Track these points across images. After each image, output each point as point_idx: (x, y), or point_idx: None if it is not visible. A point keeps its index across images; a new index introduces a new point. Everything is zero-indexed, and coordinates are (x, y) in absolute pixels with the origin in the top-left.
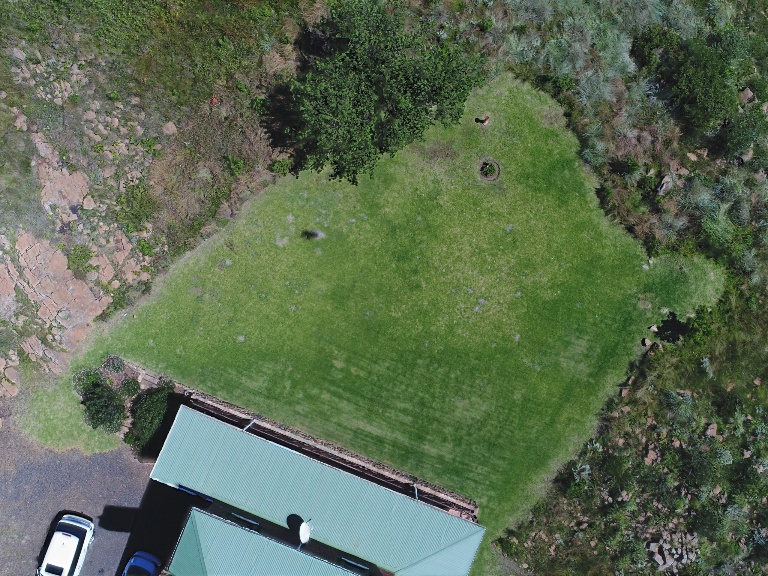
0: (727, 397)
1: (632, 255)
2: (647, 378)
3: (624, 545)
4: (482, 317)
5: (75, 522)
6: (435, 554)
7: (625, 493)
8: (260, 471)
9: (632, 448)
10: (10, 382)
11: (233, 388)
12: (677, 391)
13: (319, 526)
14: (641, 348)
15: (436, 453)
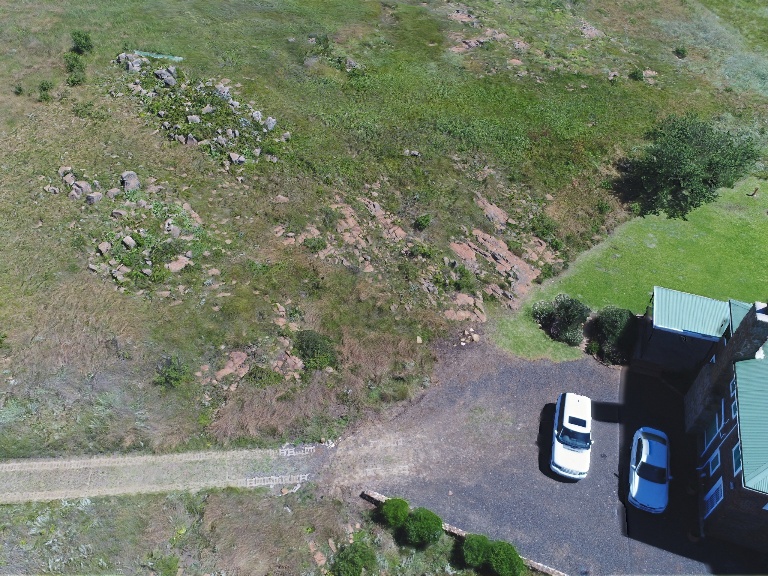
0: None
1: None
2: None
3: None
4: None
5: None
6: None
7: None
8: None
9: None
10: (481, 311)
11: None
12: None
13: None
14: None
15: None
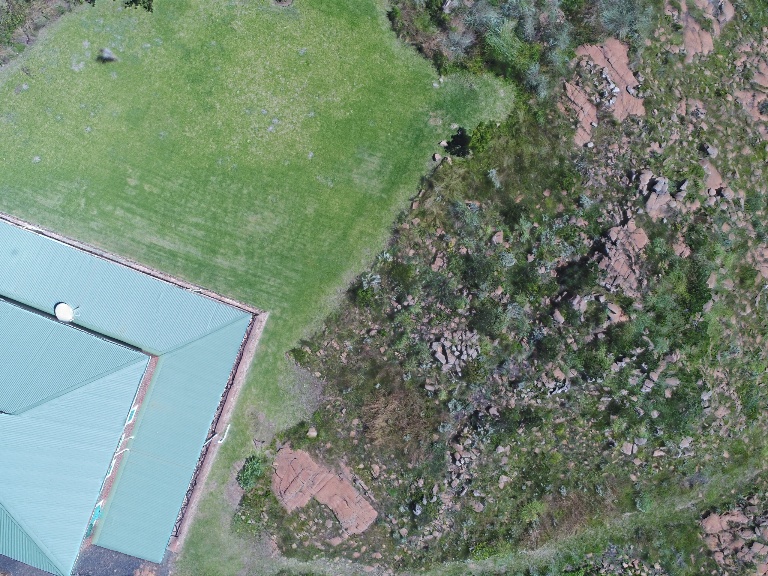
0: (514, 206)
1: (423, 74)
2: (434, 188)
3: (411, 348)
4: (276, 136)
5: None
6: (201, 339)
7: (411, 297)
8: (29, 262)
9: (421, 257)
10: None
11: (28, 206)
12: (466, 202)
13: (86, 313)
14: (432, 163)
15: (228, 266)
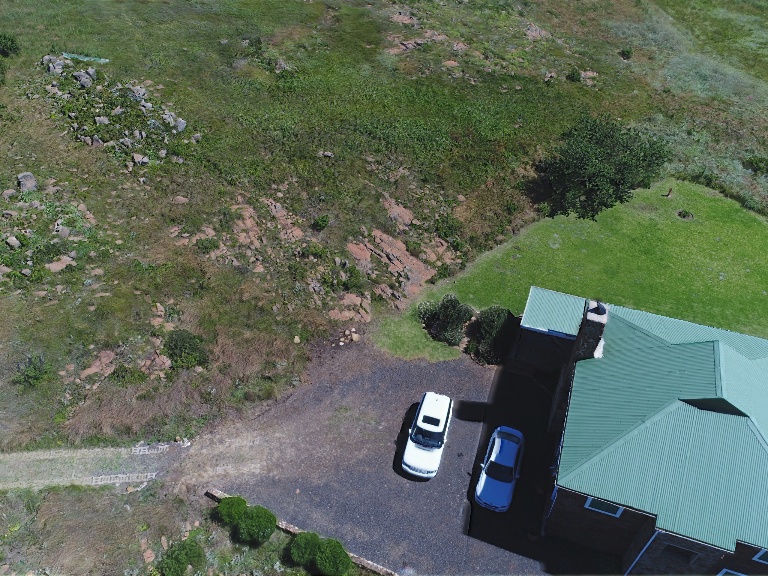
0: None
1: None
2: None
3: None
4: (728, 282)
5: None
6: None
7: None
8: None
9: None
10: (366, 311)
11: None
12: None
13: None
14: None
15: None
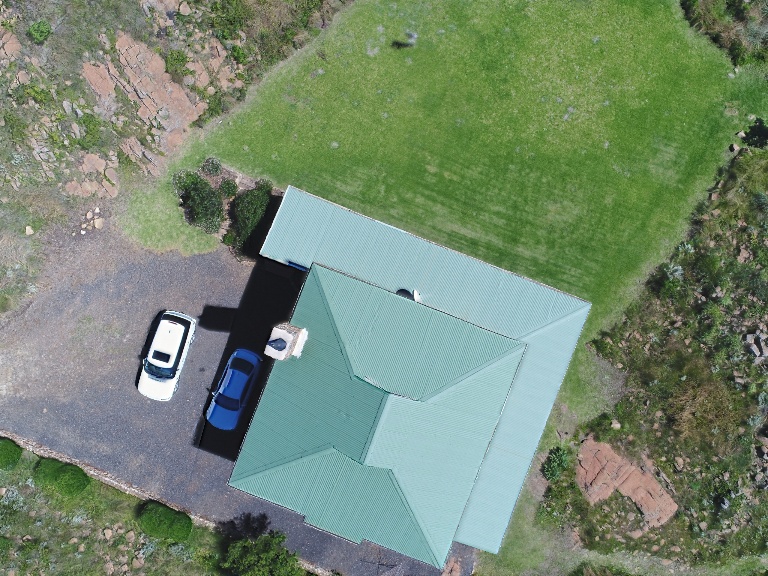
0: None
1: (718, 64)
2: (737, 179)
3: (719, 340)
4: (571, 125)
5: (179, 315)
6: (543, 328)
7: (719, 289)
8: (368, 248)
9: (724, 248)
10: (110, 183)
11: (328, 193)
12: (766, 193)
13: (428, 300)
14: (729, 154)
15: (530, 255)
